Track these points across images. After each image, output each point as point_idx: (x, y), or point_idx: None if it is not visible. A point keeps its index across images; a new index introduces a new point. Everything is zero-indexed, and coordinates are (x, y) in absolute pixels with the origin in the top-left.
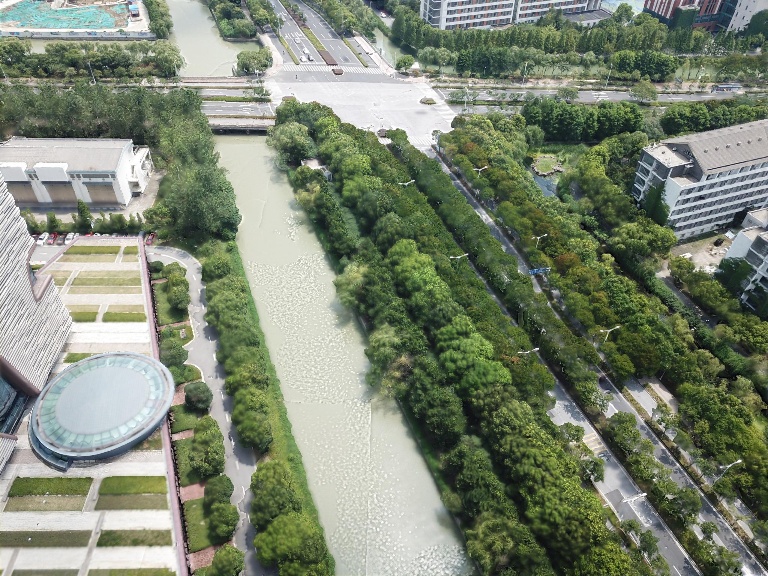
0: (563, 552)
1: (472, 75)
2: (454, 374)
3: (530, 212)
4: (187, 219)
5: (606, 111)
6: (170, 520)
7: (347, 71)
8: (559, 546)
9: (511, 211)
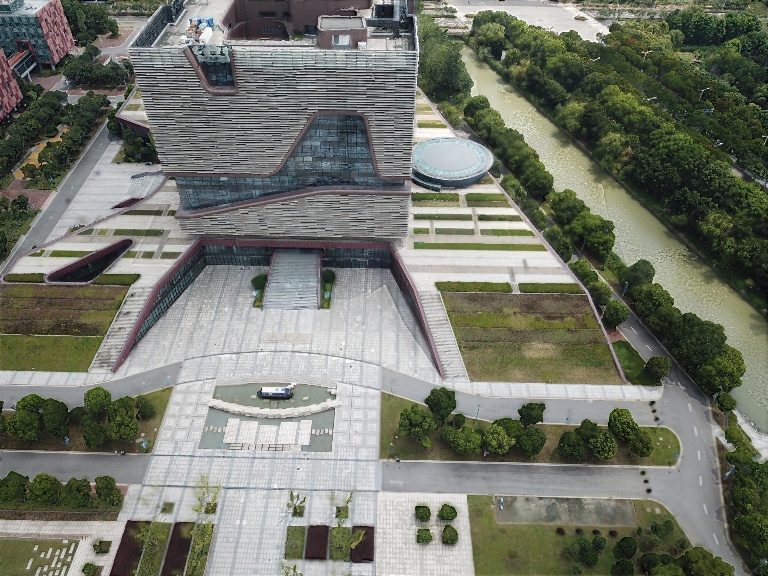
0: (765, 229)
1: (610, 2)
2: (666, 157)
3: (691, 78)
4: (444, 78)
5: (733, 19)
6: (516, 212)
7: None
8: (762, 226)
9: (676, 78)
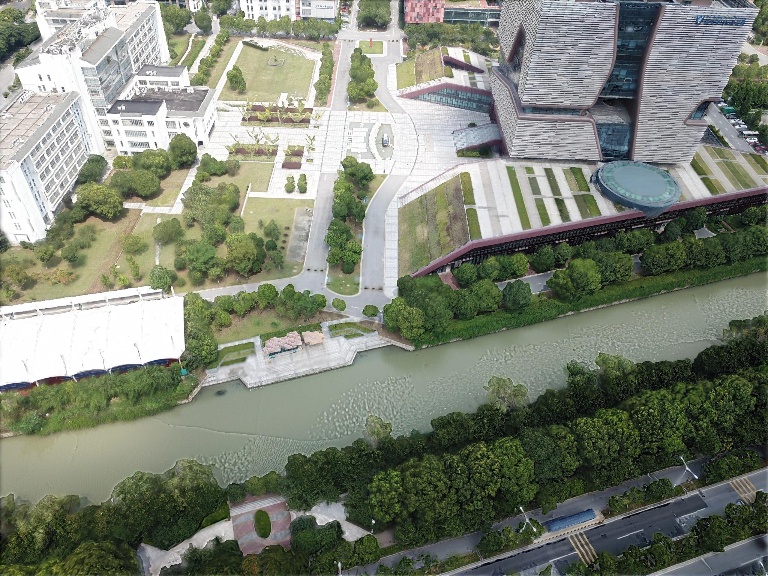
0: None
1: None
2: None
3: None
4: None
5: None
6: (577, 221)
7: None
8: None
9: None
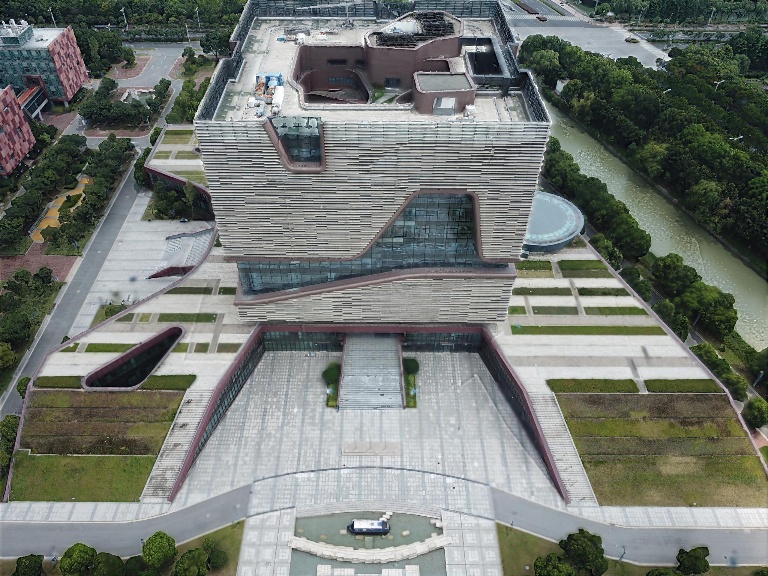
0: None
1: None
2: None
3: None
4: None
5: None
6: (620, 283)
7: (549, 18)
8: None
9: (756, 112)
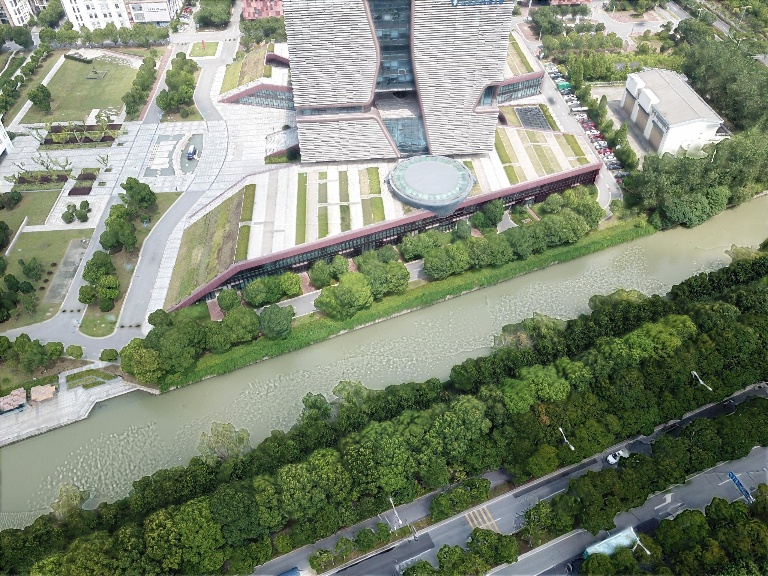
0: None
1: None
2: None
3: None
4: None
5: None
6: (357, 228)
7: None
8: None
9: None
